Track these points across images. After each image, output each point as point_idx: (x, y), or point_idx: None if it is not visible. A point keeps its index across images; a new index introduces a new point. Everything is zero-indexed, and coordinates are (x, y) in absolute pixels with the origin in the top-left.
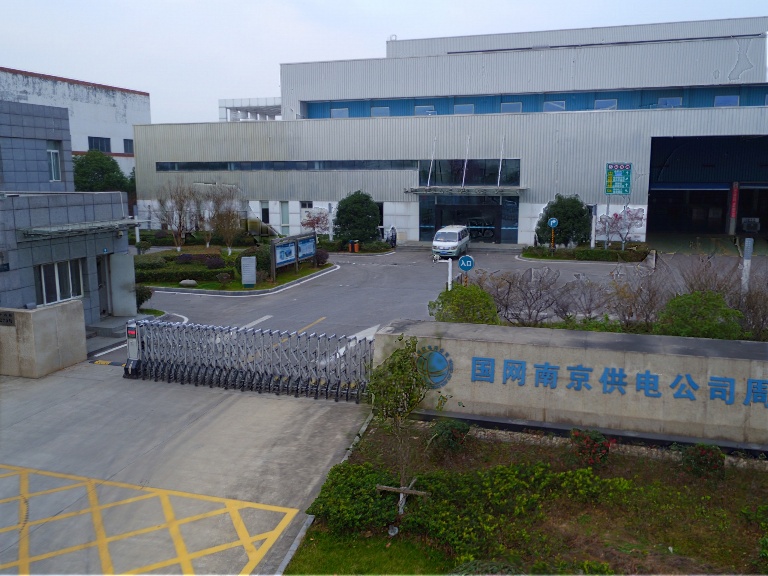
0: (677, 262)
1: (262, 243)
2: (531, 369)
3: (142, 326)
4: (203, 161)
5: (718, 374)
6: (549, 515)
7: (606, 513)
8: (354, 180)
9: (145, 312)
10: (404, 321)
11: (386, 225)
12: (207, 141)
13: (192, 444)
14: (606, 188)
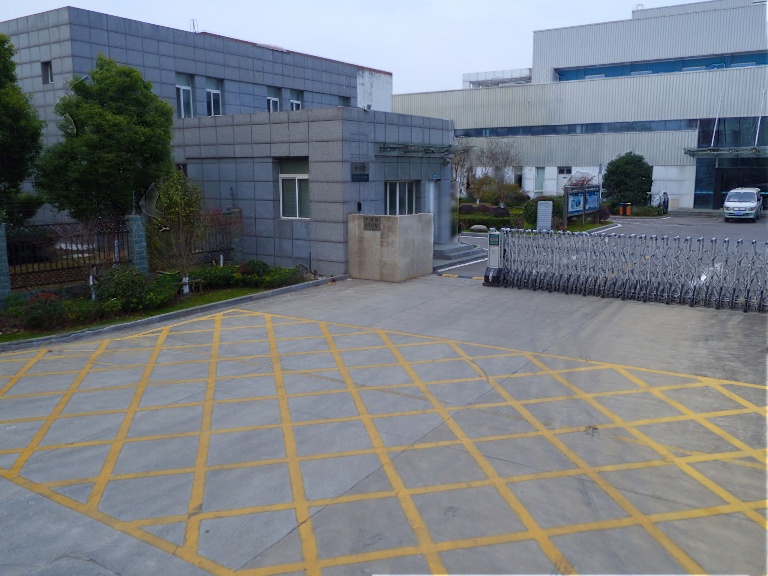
0: None
1: None
2: None
3: (504, 234)
4: (458, 128)
5: None
6: None
7: None
8: (620, 143)
9: None
10: None
11: (655, 191)
12: (463, 108)
13: (608, 334)
14: None
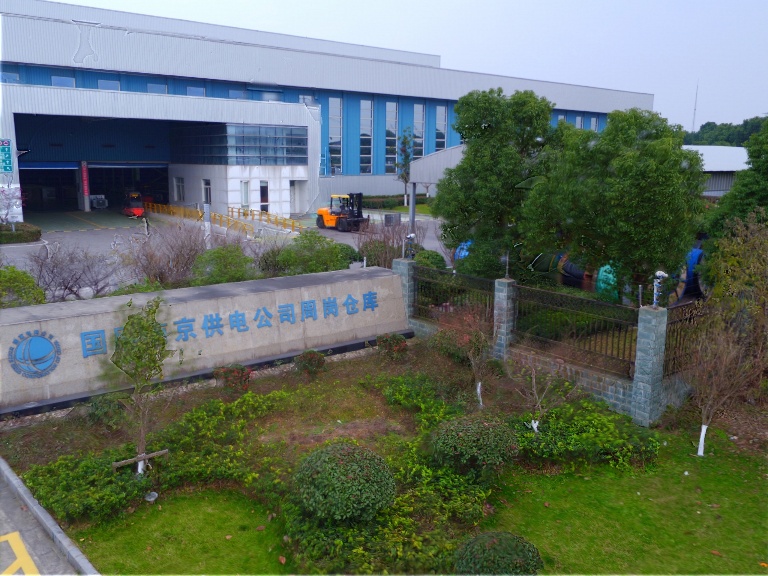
0: (158, 228)
1: None
2: None
3: None
4: None
5: (283, 302)
6: None
7: (282, 418)
8: None
9: None
10: None
11: None
12: None
13: None
14: None
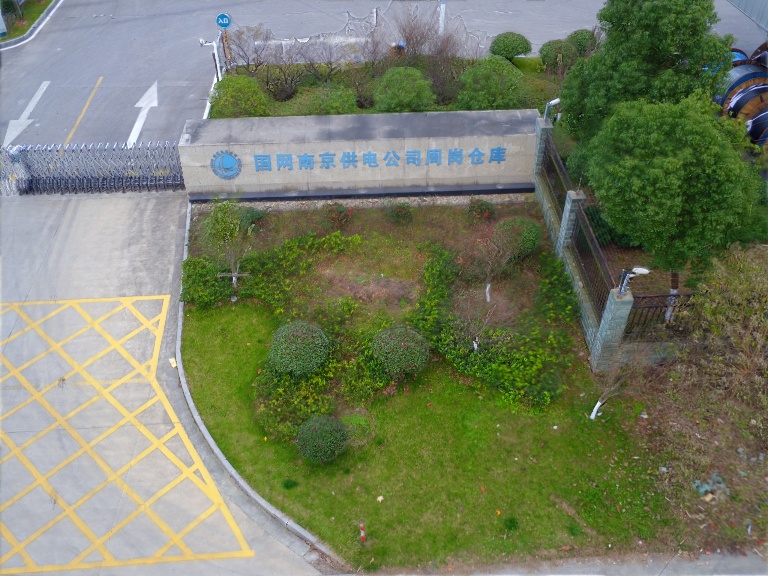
0: (393, 12)
1: None
2: (295, 159)
3: None
4: None
5: (411, 149)
6: (319, 267)
7: (349, 258)
8: None
9: None
10: (194, 123)
11: None
12: None
13: (68, 257)
14: None
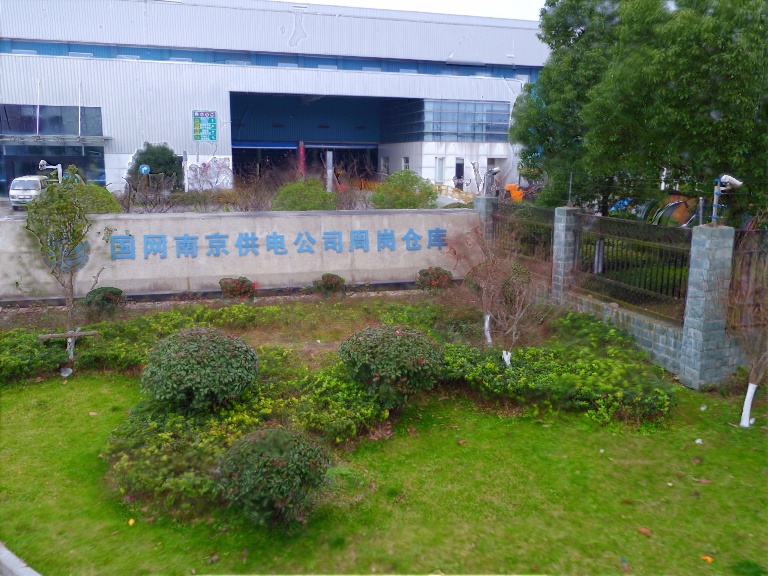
0: (276, 172)
1: None
2: (171, 242)
3: None
4: None
5: (329, 229)
6: None
7: (263, 331)
8: None
9: None
10: None
11: None
12: None
13: None
14: (194, 135)
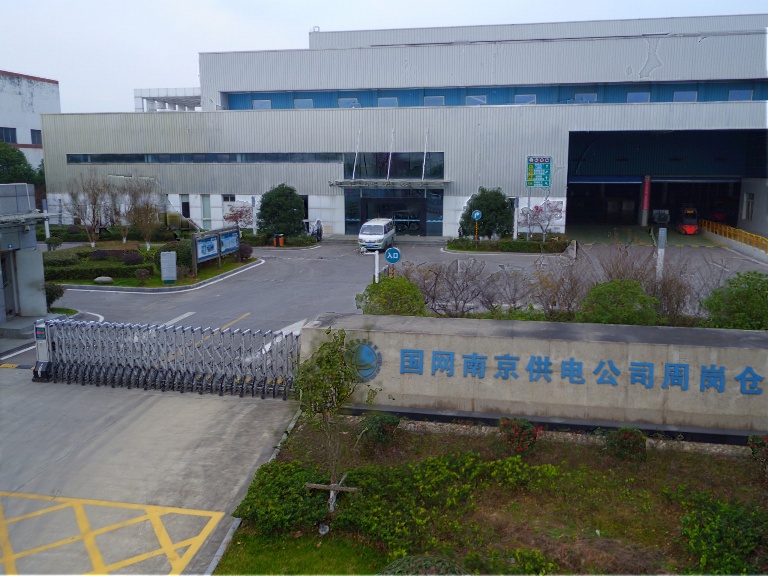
0: (596, 252)
1: (183, 238)
2: (459, 360)
3: (52, 326)
4: (118, 153)
5: (638, 359)
6: (480, 505)
7: (535, 500)
8: (278, 173)
9: (56, 311)
10: (331, 314)
11: (311, 219)
12: (122, 132)
13: (109, 449)
14: (527, 181)
